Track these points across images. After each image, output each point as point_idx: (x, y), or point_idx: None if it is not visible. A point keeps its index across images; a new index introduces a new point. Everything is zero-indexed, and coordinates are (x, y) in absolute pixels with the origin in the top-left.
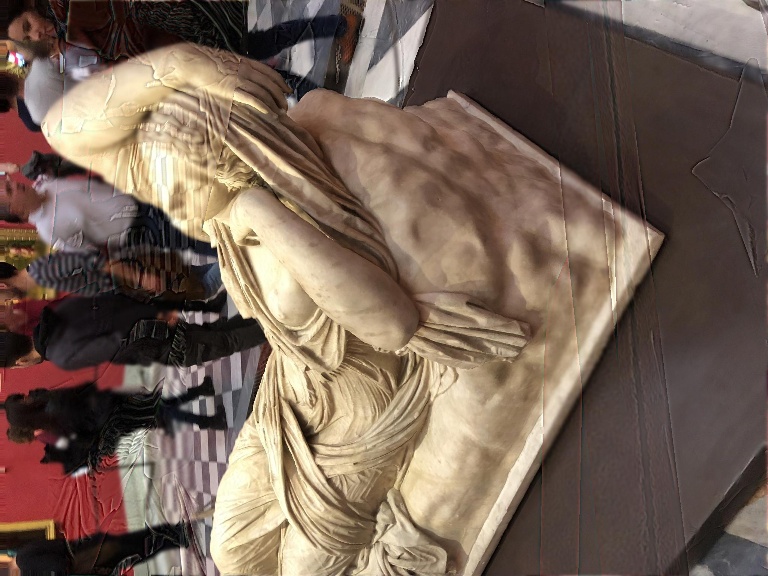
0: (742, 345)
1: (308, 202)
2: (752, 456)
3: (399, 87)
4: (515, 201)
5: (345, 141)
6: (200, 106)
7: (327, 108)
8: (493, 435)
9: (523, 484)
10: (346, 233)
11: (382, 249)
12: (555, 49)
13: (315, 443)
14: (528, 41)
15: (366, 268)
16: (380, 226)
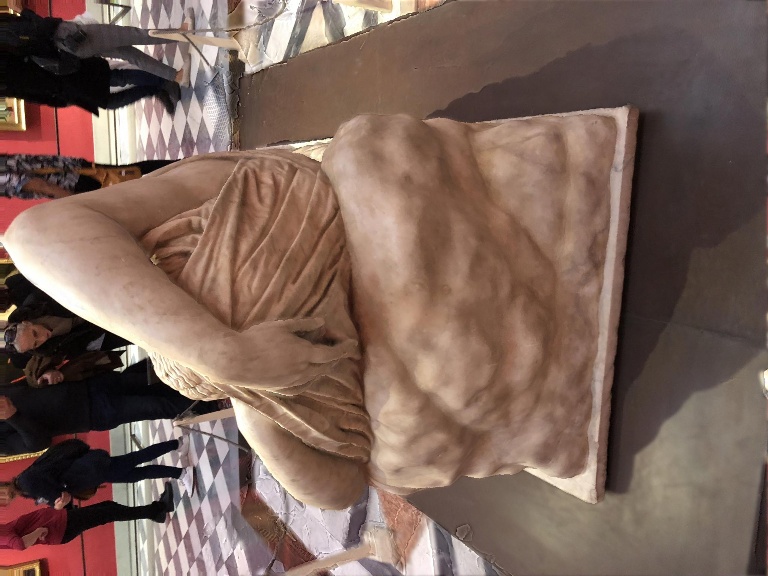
0: (569, 570)
1: (311, 437)
2: None
3: None
4: (518, 432)
5: (389, 377)
6: None
7: (398, 309)
8: None
9: None
10: (336, 452)
11: (364, 454)
12: None
13: None
14: (739, 208)
15: (334, 492)
16: (374, 440)
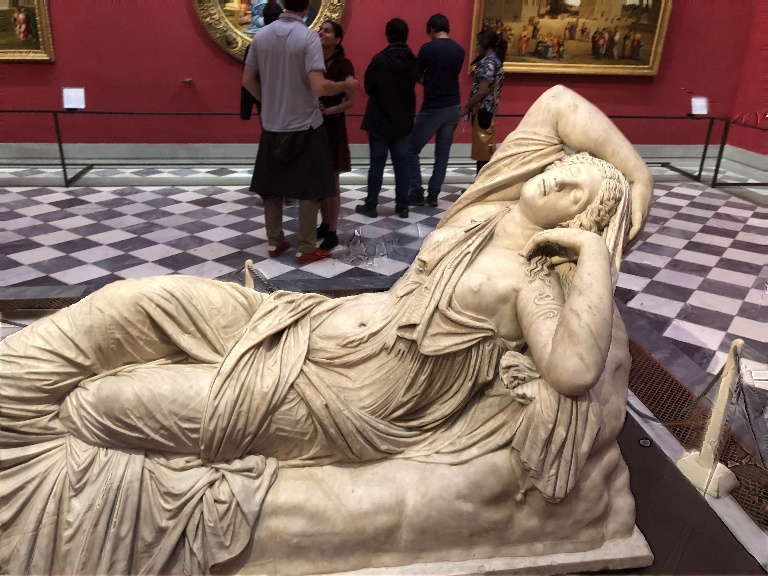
0: None
1: None
2: None
3: None
4: None
5: None
6: None
7: None
8: (423, 525)
9: None
10: None
11: None
12: None
13: None
14: None
15: None
16: None
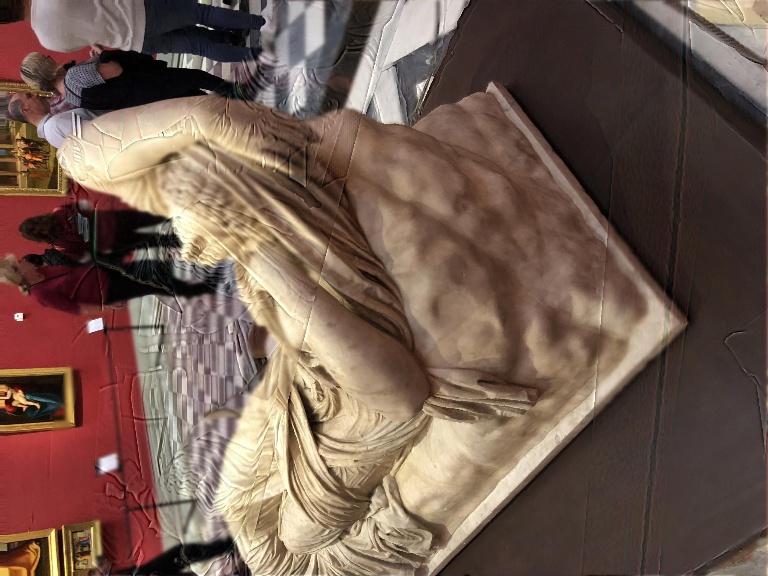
0: (740, 451)
1: (329, 272)
2: (726, 549)
3: (438, 34)
4: (541, 267)
5: (373, 196)
6: (227, 556)
7: (357, 147)
8: (488, 458)
9: (510, 495)
10: (365, 304)
11: (400, 319)
12: (591, 529)
13: (319, 432)
14: (584, 53)
15: (382, 350)
16: (400, 294)
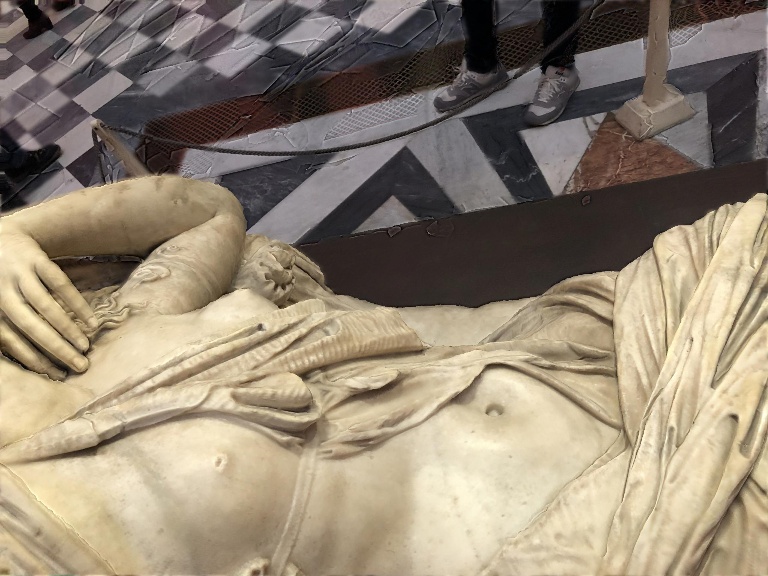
0: None
1: None
2: (350, 238)
3: None
4: None
5: None
6: None
7: None
8: None
9: None
10: None
11: None
12: None
13: None
14: None
15: None
16: None
